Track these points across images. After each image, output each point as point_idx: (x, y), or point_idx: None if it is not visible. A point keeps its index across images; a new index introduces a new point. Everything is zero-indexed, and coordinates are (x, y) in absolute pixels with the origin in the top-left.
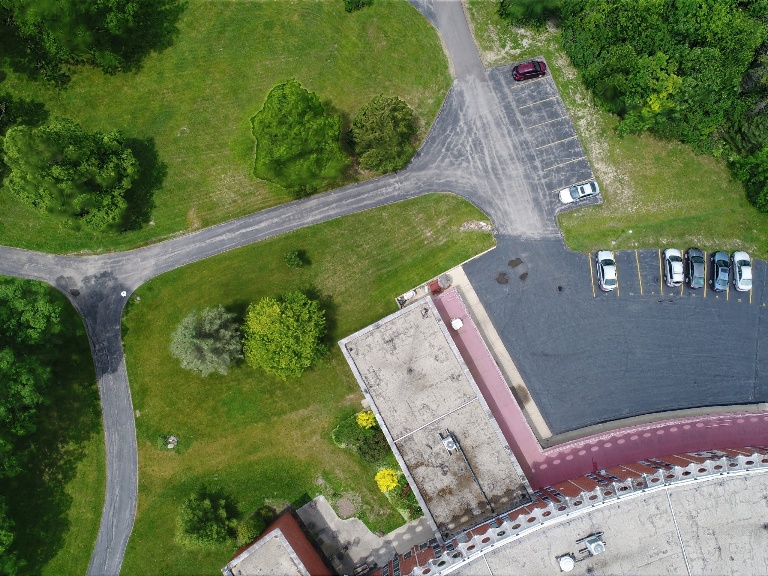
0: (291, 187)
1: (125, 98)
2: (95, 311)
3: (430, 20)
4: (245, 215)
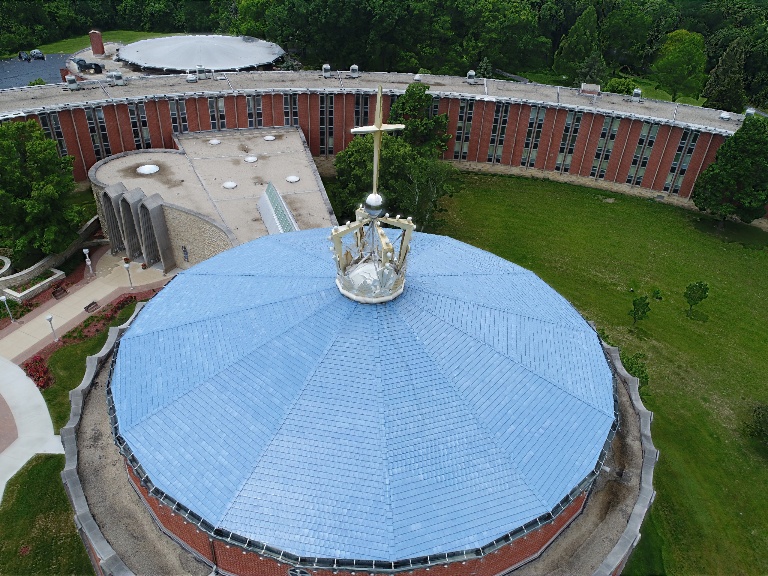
0: (667, 85)
1: None
2: None
3: None
4: None
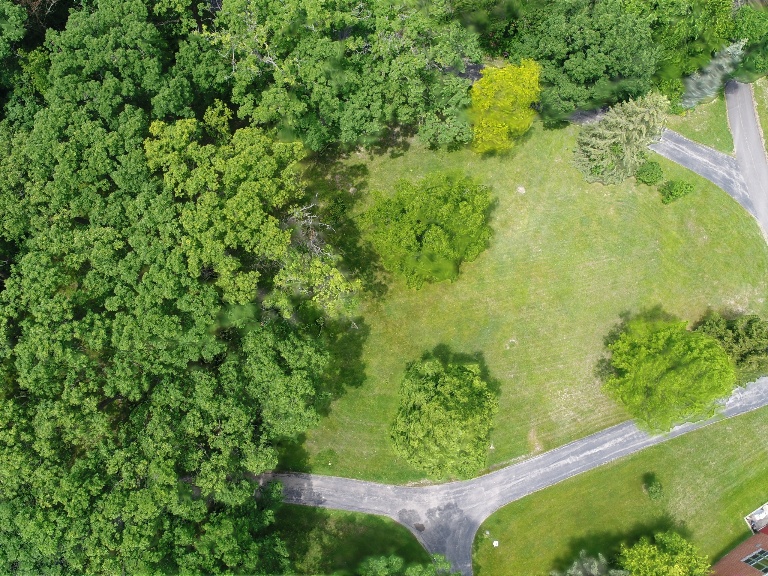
0: None
1: (447, 308)
2: (443, 548)
3: (748, 209)
4: (587, 435)
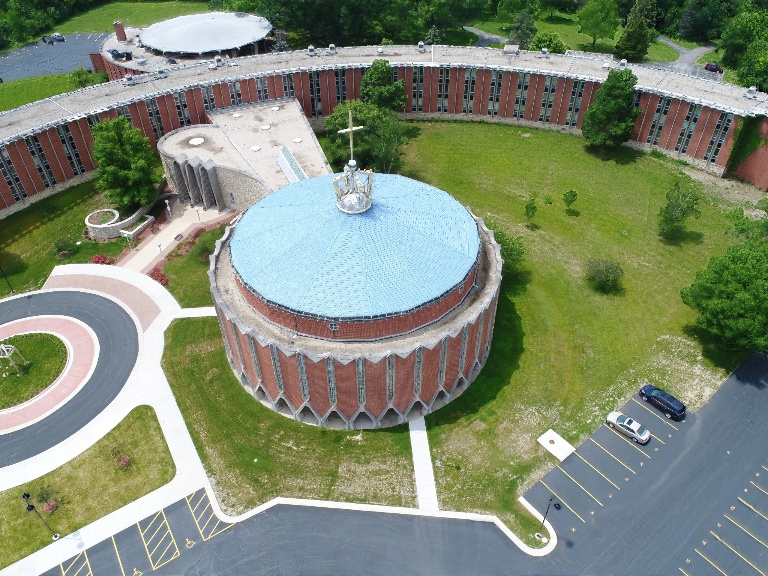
0: (586, 30)
1: None
2: None
3: None
4: None
